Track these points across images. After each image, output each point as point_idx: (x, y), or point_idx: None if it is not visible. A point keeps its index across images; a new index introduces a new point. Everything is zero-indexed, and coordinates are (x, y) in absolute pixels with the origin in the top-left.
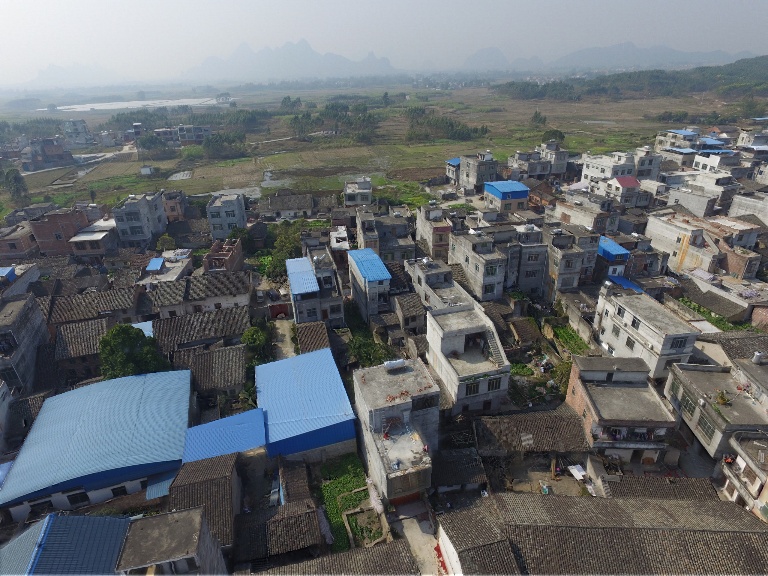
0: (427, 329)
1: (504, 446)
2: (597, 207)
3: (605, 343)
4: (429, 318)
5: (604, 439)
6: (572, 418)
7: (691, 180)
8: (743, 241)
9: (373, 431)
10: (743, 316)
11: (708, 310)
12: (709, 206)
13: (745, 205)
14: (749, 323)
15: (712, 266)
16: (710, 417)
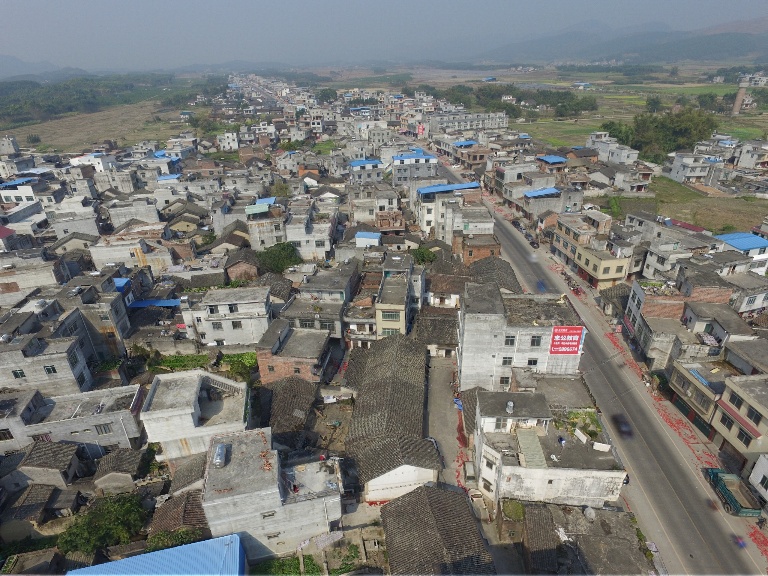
0: (149, 431)
1: (299, 430)
2: (38, 261)
3: (211, 342)
4: (150, 417)
5: (318, 371)
6: (293, 380)
7: (54, 210)
8: (167, 236)
9: (283, 503)
10: (225, 278)
11: (207, 287)
12: (98, 225)
13: (122, 214)
14: (231, 280)
15: (173, 260)
16: (329, 319)
